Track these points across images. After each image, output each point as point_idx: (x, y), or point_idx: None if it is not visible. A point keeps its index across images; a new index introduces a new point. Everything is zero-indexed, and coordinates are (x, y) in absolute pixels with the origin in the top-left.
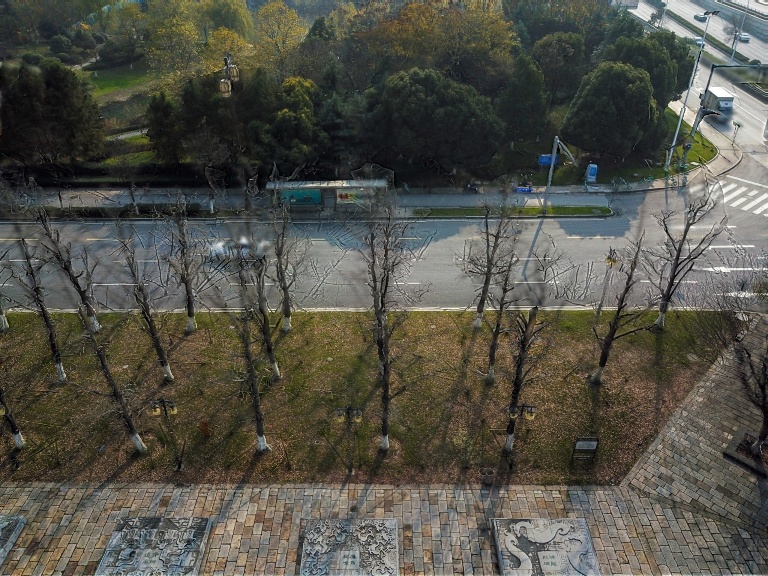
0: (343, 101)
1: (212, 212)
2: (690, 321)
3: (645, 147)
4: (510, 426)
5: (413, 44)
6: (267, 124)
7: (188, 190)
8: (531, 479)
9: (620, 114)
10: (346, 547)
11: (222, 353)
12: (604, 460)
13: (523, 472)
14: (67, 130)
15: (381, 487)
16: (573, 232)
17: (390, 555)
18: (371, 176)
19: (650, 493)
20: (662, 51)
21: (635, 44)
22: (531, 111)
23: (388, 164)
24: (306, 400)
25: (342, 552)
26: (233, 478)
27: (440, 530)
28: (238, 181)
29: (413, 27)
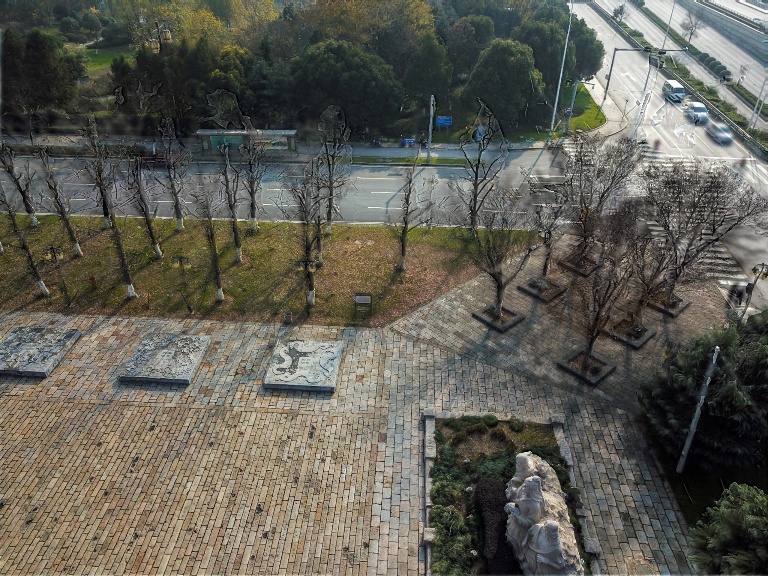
0: (269, 65)
1: (154, 153)
2: (500, 236)
3: (537, 115)
4: (310, 284)
5: (338, 21)
6: (202, 82)
7: (140, 137)
8: (321, 322)
9: (505, 83)
10: (167, 348)
11: (125, 242)
12: (380, 314)
13: (317, 318)
14: (44, 85)
15: (209, 321)
16: (445, 176)
17: (196, 353)
18: (220, 99)
19: (403, 333)
20: (560, 33)
21: (534, 26)
22: (433, 80)
23: (313, 123)
24: (176, 271)
25: (163, 350)
26: (105, 312)
27: (240, 345)
28: (183, 132)
29: (346, 8)
